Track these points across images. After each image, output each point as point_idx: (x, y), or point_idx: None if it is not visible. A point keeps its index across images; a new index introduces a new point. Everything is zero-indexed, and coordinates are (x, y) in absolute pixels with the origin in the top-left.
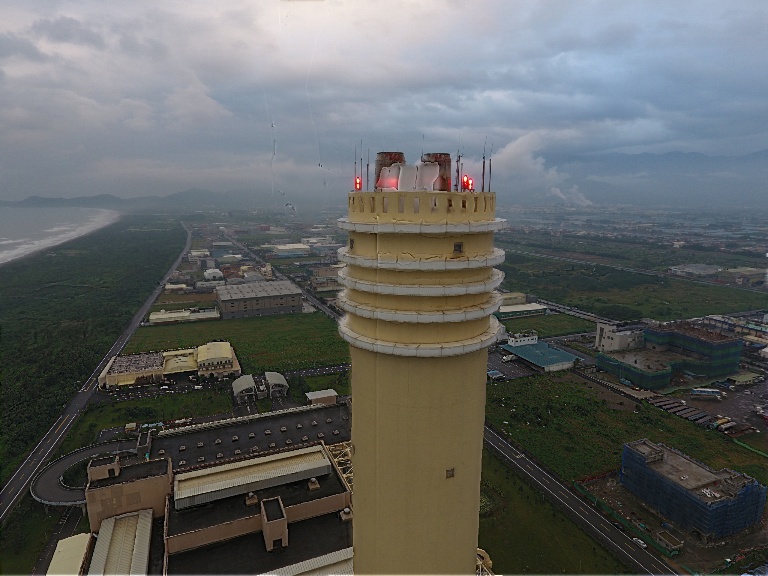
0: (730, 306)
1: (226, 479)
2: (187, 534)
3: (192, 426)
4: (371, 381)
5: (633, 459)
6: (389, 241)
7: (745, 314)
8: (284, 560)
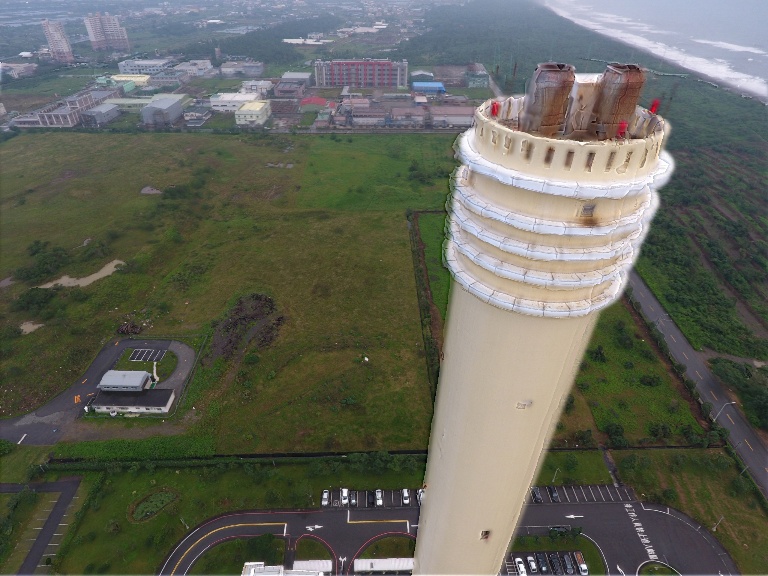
0: None
1: None
2: None
3: None
4: None
5: None
6: None
7: None
8: None
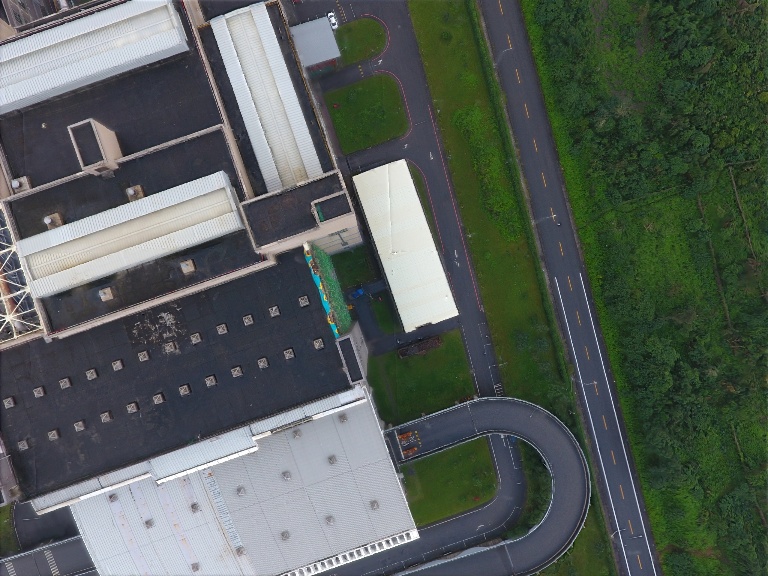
0: None
1: (168, 217)
2: (199, 131)
3: (368, 554)
4: None
5: None
6: None
7: None
8: (94, 119)
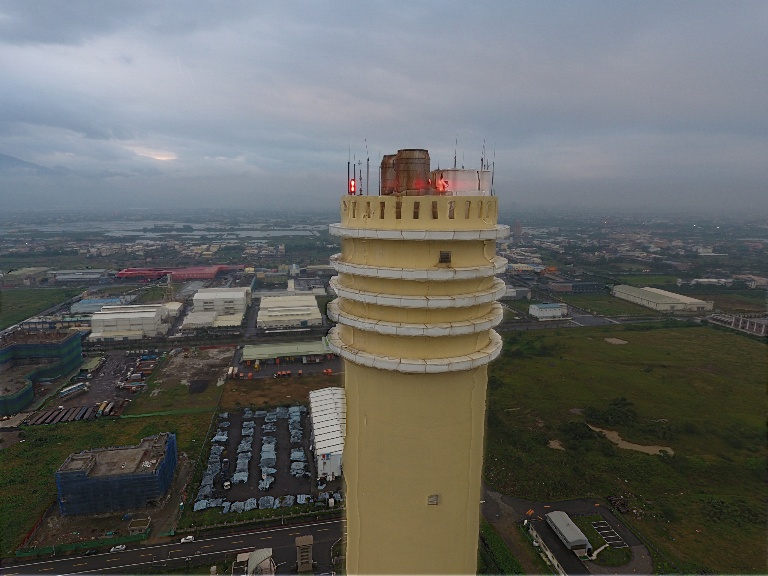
0: (35, 307)
1: None
2: None
3: None
4: (466, 401)
5: (71, 481)
6: (490, 246)
7: (53, 310)
8: None
